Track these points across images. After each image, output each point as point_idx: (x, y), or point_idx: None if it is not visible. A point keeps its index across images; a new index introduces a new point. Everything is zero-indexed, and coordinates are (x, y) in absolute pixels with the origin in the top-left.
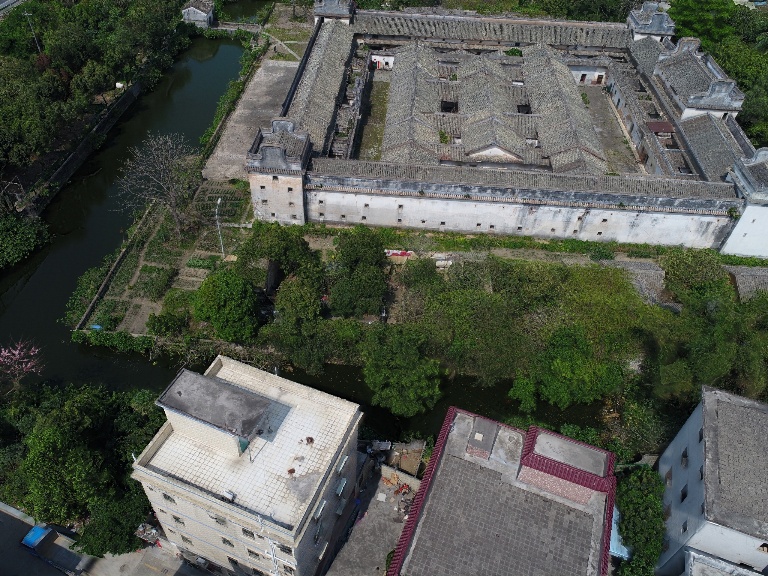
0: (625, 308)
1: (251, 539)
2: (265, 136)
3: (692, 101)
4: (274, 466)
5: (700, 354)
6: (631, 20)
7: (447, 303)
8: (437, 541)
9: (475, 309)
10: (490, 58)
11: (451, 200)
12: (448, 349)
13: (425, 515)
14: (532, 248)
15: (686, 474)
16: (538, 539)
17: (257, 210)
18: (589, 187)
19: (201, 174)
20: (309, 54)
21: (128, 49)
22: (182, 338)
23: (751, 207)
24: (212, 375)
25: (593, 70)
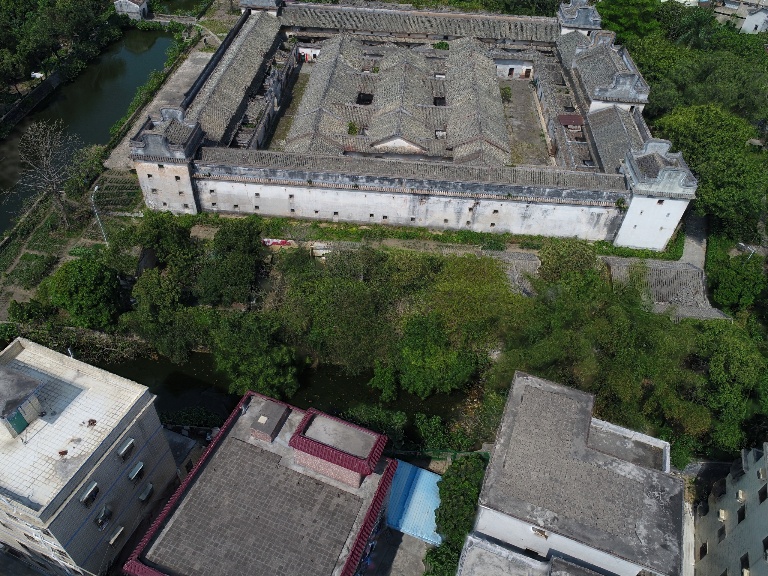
0: (486, 297)
1: (16, 521)
2: (156, 124)
3: (598, 93)
4: (47, 448)
5: (536, 341)
6: (560, 14)
7: (311, 291)
8: (193, 523)
9: (336, 297)
10: (415, 51)
11: (340, 190)
12: (307, 337)
13: (189, 497)
14: (424, 239)
15: None
16: (299, 522)
17: (148, 199)
18: (479, 178)
19: (101, 163)
20: (229, 45)
21: (44, 39)
22: (46, 325)
23: (637, 198)
24: (10, 357)
25: (520, 64)
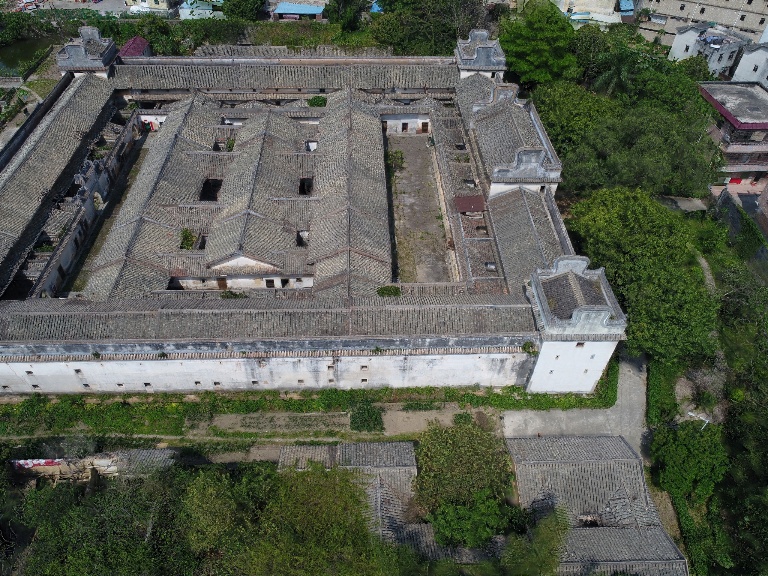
0: None
1: None
2: None
3: (497, 175)
4: None
5: None
6: (457, 53)
7: None
8: None
9: None
10: None
11: (143, 360)
12: None
13: None
14: (272, 410)
15: None
16: None
17: None
18: (336, 325)
19: None
20: (34, 127)
21: None
22: None
23: (549, 343)
24: None
25: (414, 117)
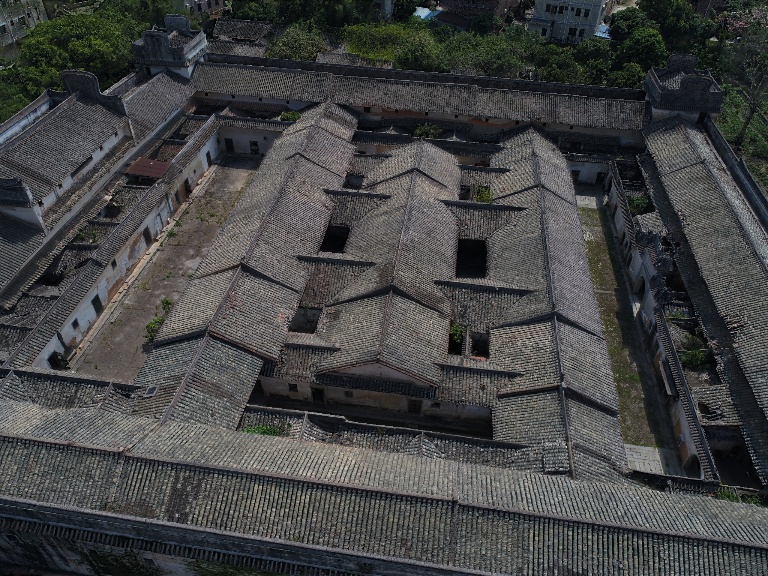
0: None
1: None
2: None
3: None
4: None
5: None
6: None
7: None
8: None
9: None
10: None
11: None
12: None
13: None
14: None
15: None
16: None
17: None
18: None
19: None
20: None
21: None
22: None
23: None
24: None
25: None
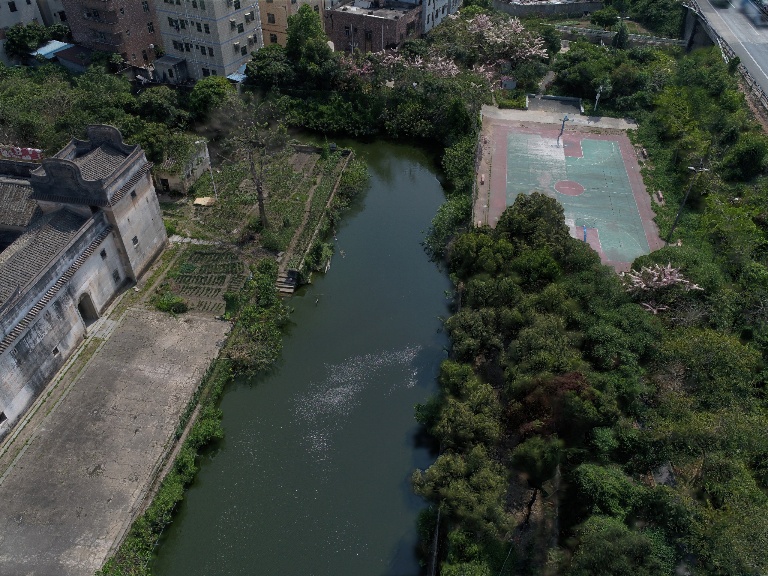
0: None
1: None
2: None
3: None
4: None
5: None
6: None
7: None
8: None
9: None
10: None
11: None
12: None
13: None
14: None
15: (3, 5)
16: None
17: None
18: None
19: None
20: None
21: None
22: None
23: None
24: None
25: None
